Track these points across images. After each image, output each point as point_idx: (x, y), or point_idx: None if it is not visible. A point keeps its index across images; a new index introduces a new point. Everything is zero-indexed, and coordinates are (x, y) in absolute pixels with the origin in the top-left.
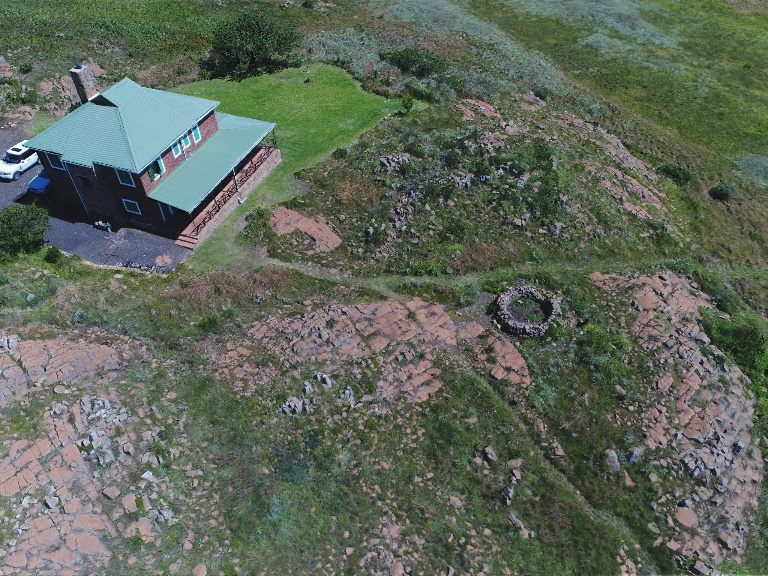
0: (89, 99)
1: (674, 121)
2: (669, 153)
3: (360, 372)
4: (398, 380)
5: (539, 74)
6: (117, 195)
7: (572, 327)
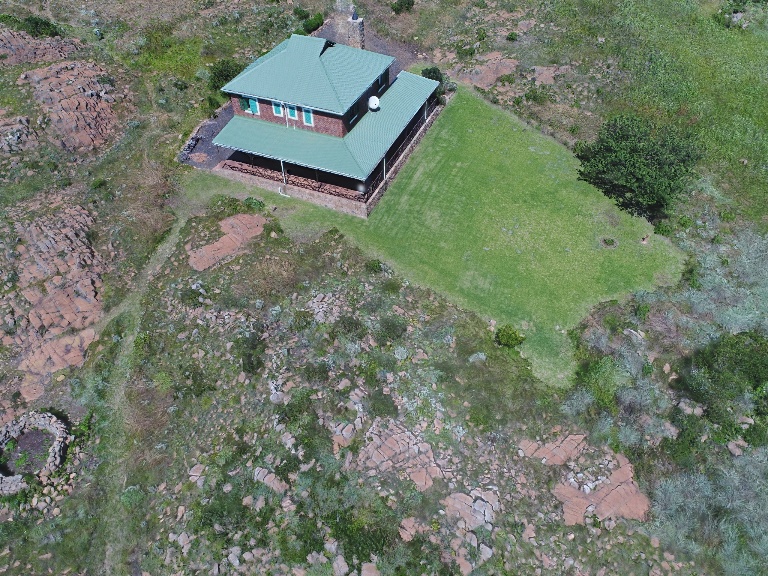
0: None
1: None
2: None
3: (2, 278)
4: None
5: None
6: None
7: None
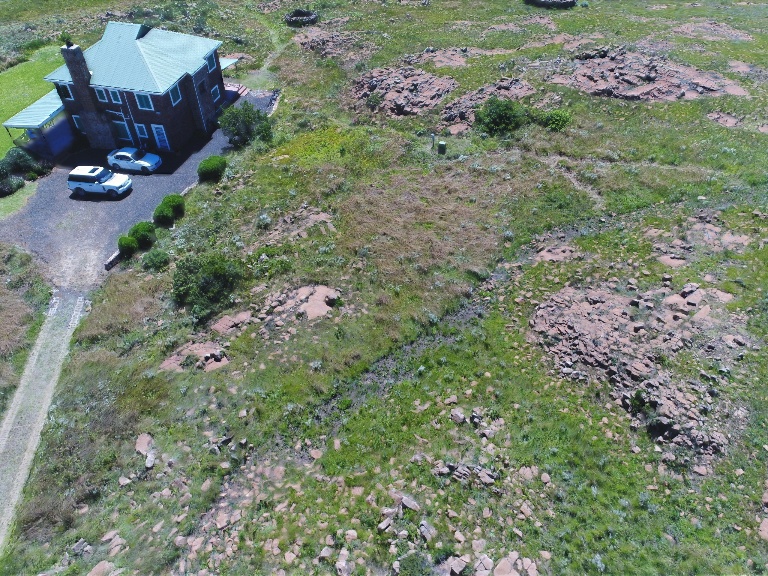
0: (90, 74)
1: (83, 7)
2: (127, 8)
3: None
4: None
5: None
6: None
7: None
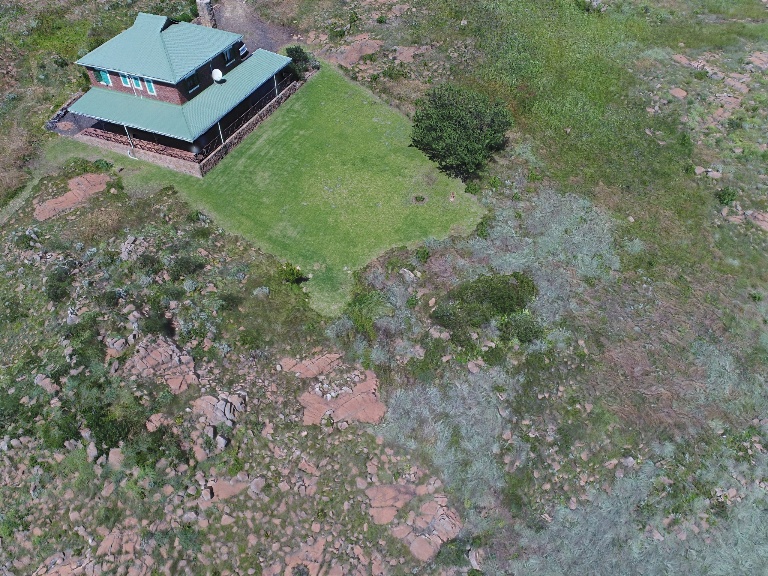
0: None
1: None
2: None
3: None
4: None
5: (563, 574)
6: None
7: None
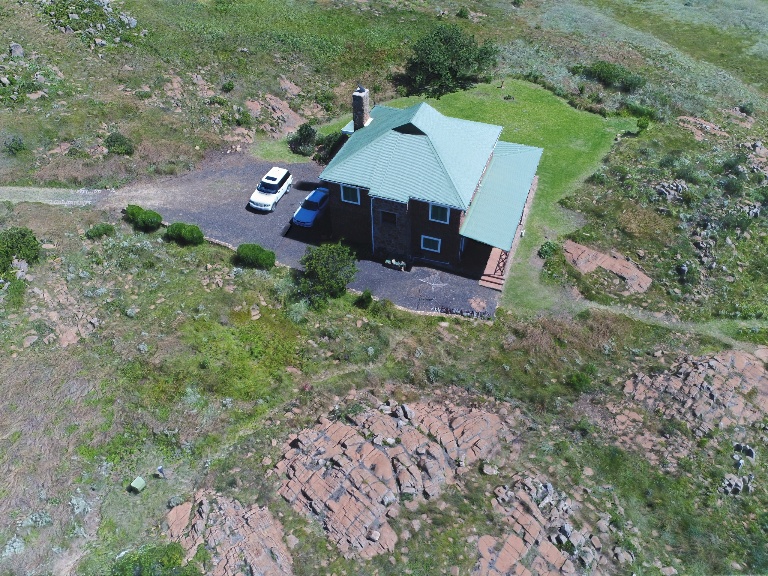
0: (365, 125)
1: None
2: None
3: None
4: None
5: (732, 88)
6: (417, 231)
7: None
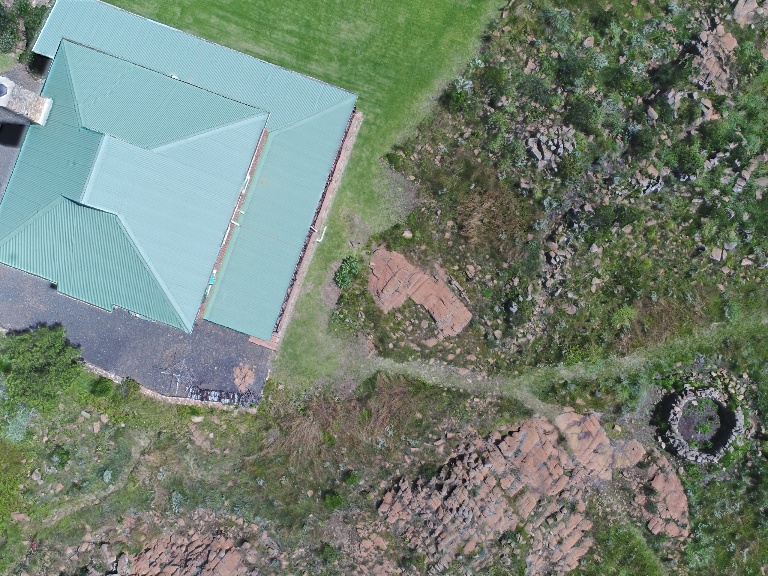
0: (39, 121)
1: None
2: None
3: (508, 552)
4: (548, 549)
5: None
6: None
7: (749, 439)
